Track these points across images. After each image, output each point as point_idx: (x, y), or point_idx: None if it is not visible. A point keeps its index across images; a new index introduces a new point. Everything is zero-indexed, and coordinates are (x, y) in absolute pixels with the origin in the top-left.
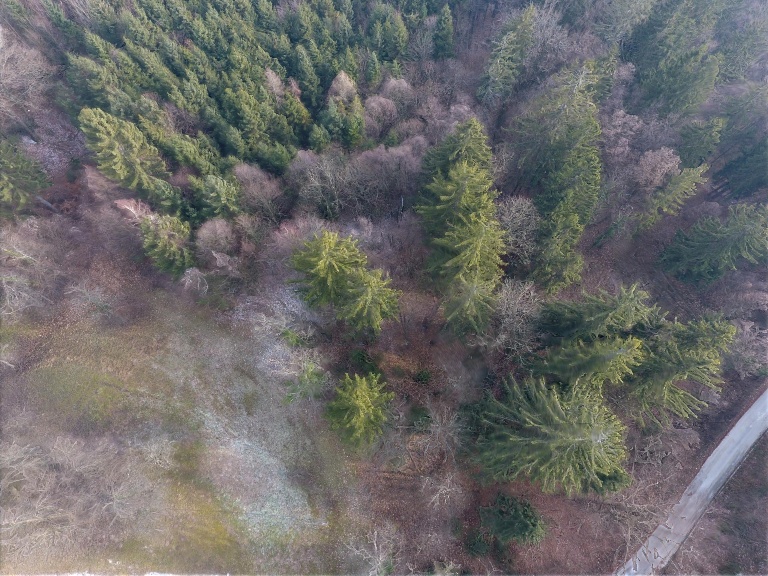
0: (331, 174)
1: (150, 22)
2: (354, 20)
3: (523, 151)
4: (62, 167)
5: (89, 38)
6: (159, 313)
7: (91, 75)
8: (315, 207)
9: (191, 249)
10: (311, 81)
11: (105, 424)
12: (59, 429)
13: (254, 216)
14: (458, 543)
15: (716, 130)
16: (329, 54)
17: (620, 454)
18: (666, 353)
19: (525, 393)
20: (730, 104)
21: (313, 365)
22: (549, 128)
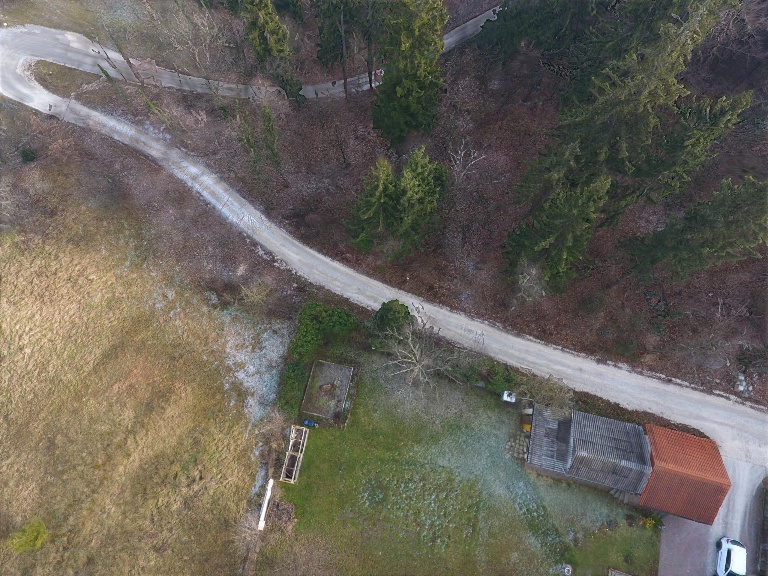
0: None
1: None
2: None
3: None
4: None
5: None
6: None
7: None
8: None
9: None
10: None
11: None
12: None
13: None
14: None
15: None
16: None
17: None
18: None
19: None
20: None
21: None
22: None
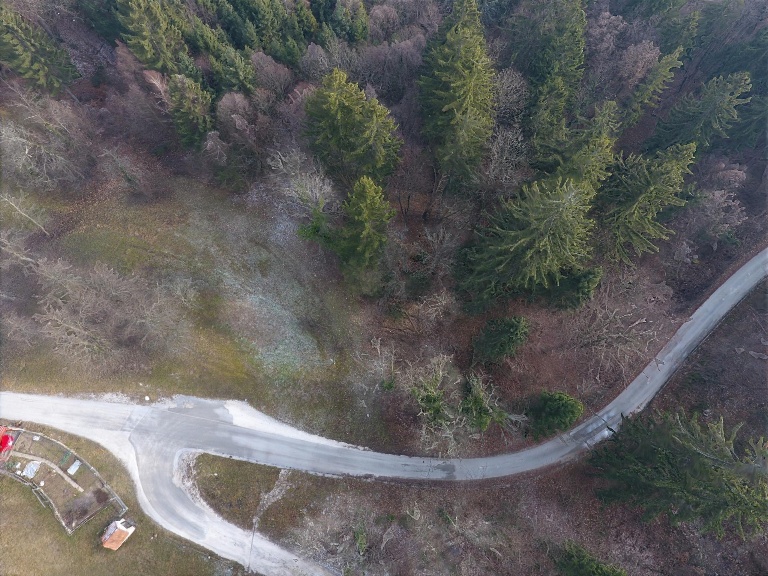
0: (339, 57)
1: None
2: None
3: (516, 47)
4: (87, 76)
5: None
6: (180, 196)
7: None
8: None
9: (212, 118)
10: None
11: None
12: None
13: (269, 91)
14: (453, 389)
15: (693, 26)
16: None
17: (587, 208)
18: (636, 176)
19: None
20: (709, 11)
21: None
22: (539, 21)
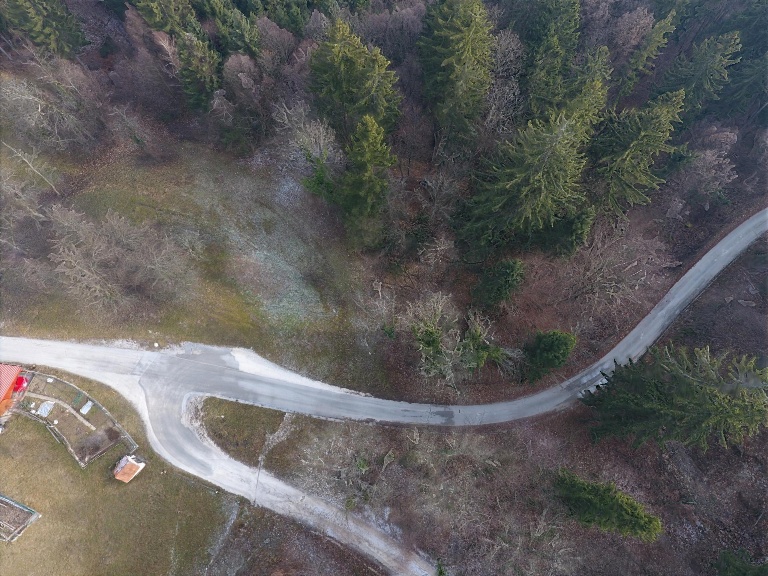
0: None
1: None
2: None
3: (514, 15)
4: (95, 47)
5: None
6: (186, 159)
7: None
8: None
9: None
10: None
11: None
12: None
13: (274, 53)
14: None
15: None
16: None
17: (579, 139)
18: (628, 124)
19: (508, 158)
20: None
21: (327, 153)
22: None
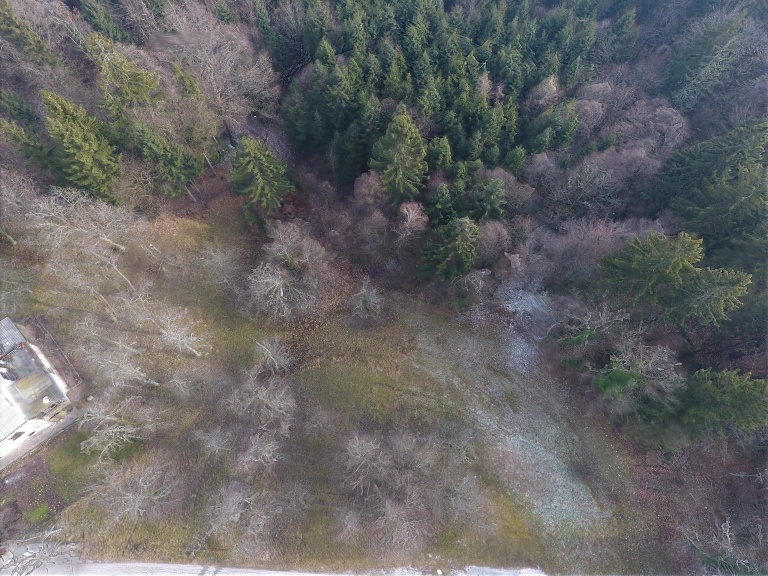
0: (591, 176)
1: (362, 28)
2: (540, 25)
3: None
4: None
5: (322, 45)
6: (398, 314)
7: (329, 81)
8: (567, 209)
9: None
10: (517, 85)
11: (387, 423)
12: (345, 428)
13: None
14: None
15: None
16: (519, 58)
17: None
18: None
19: None
20: None
21: None
22: None
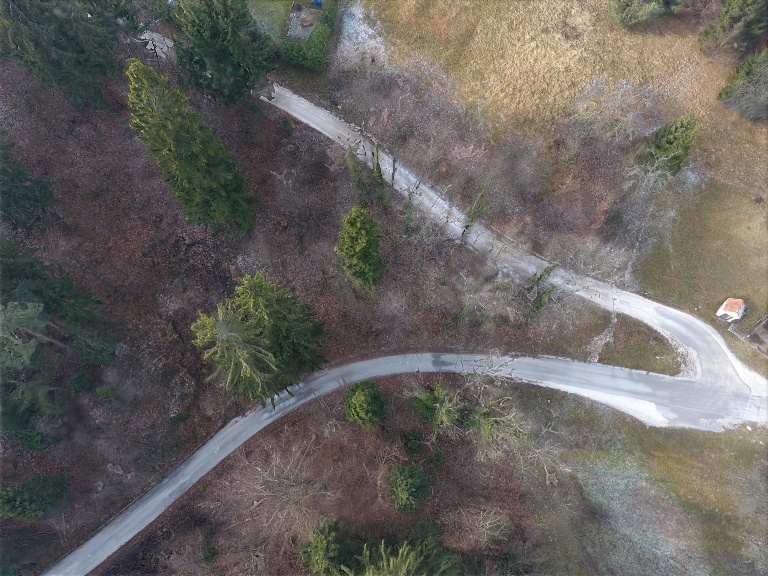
0: None
1: None
2: None
3: None
4: None
5: None
6: None
7: None
8: None
9: None
10: None
11: None
12: None
13: None
14: None
15: None
16: None
17: None
18: None
19: None
20: None
21: None
22: None
